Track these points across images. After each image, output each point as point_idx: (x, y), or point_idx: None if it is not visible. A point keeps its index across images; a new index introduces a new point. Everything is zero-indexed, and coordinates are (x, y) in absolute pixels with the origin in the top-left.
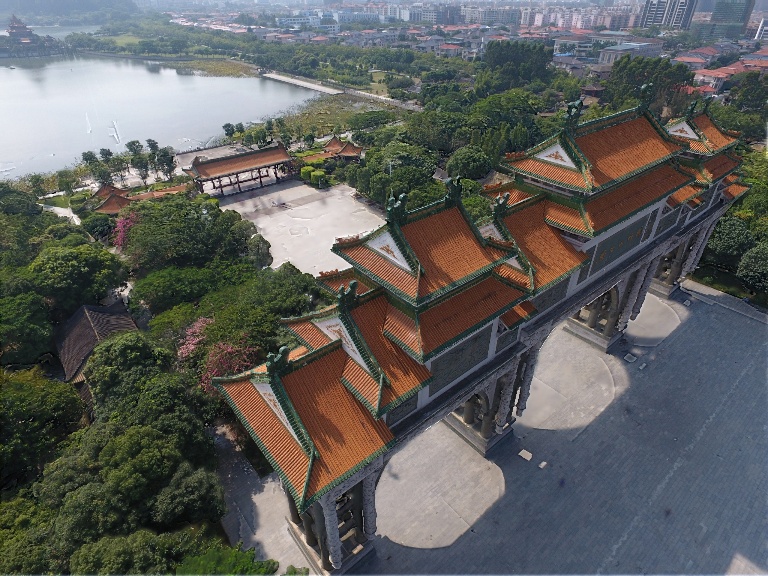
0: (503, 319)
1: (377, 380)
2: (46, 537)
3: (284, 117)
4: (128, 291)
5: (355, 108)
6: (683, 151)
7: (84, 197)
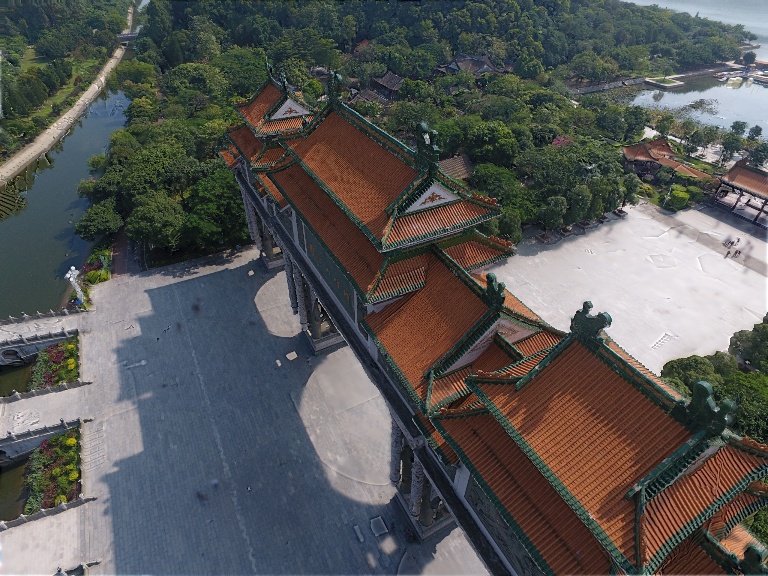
0: None
1: None
2: None
3: None
4: None
5: None
6: (374, 243)
7: None
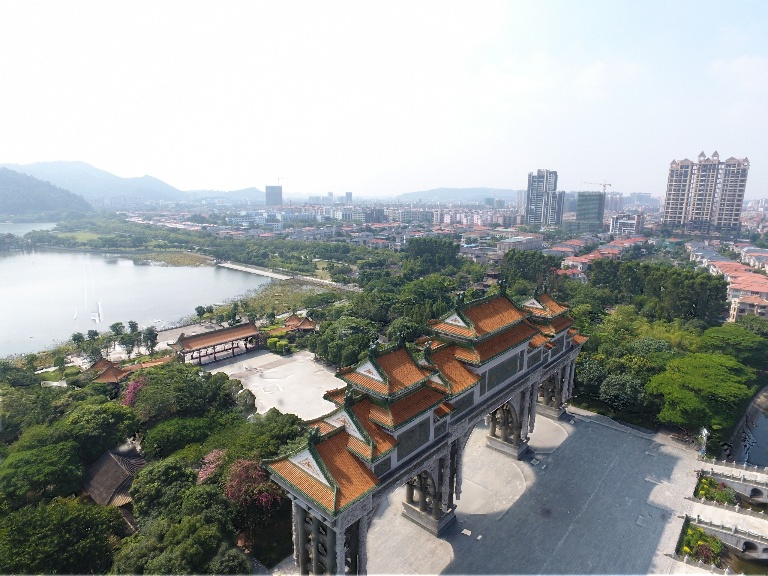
0: (436, 413)
1: (369, 444)
2: None
3: (243, 299)
4: (136, 441)
5: (304, 290)
6: None
7: (78, 370)
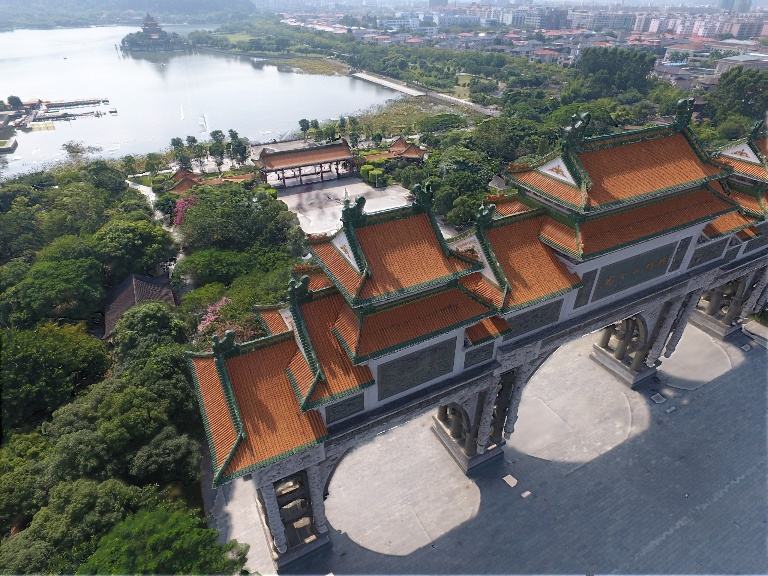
0: (469, 334)
1: (314, 375)
2: (42, 470)
3: (362, 116)
4: None
5: (433, 110)
6: (724, 175)
7: (164, 178)
